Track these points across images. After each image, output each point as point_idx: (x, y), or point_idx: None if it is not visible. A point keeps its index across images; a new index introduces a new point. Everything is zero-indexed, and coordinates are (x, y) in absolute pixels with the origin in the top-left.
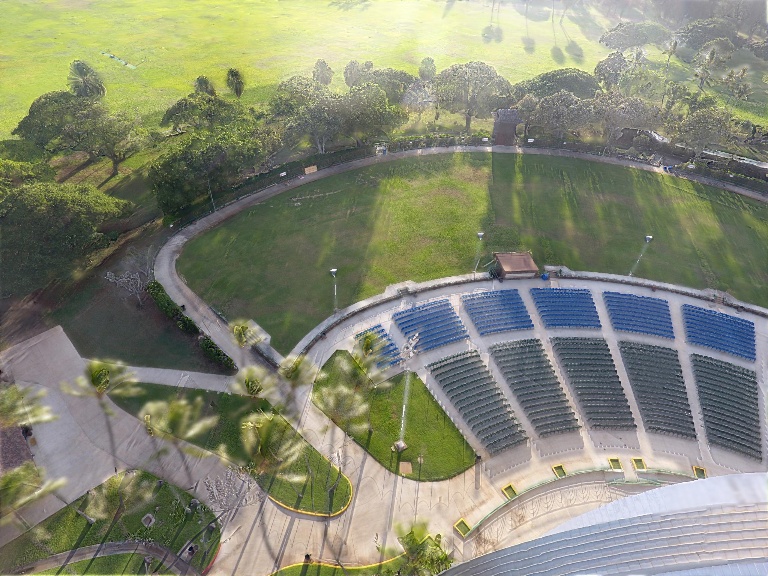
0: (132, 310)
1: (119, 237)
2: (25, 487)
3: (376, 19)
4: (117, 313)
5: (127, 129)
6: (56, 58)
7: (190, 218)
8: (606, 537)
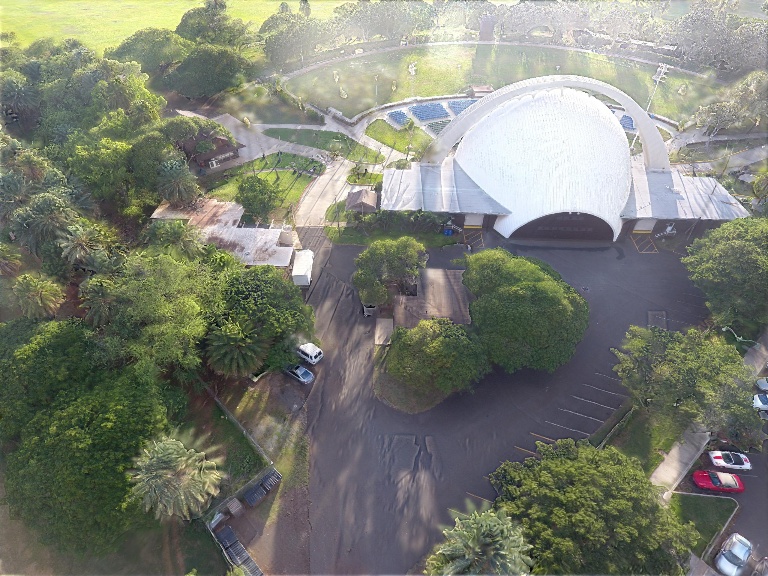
0: (266, 104)
1: (247, 84)
2: (240, 144)
3: None
4: (258, 106)
5: (244, 28)
6: (167, 6)
7: (290, 69)
8: None
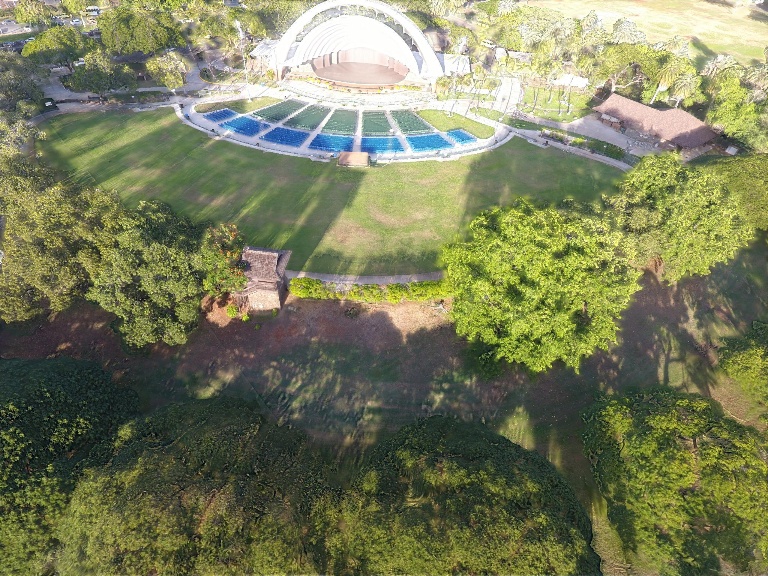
0: None
1: None
2: None
3: None
4: None
5: None
6: None
7: None
8: None
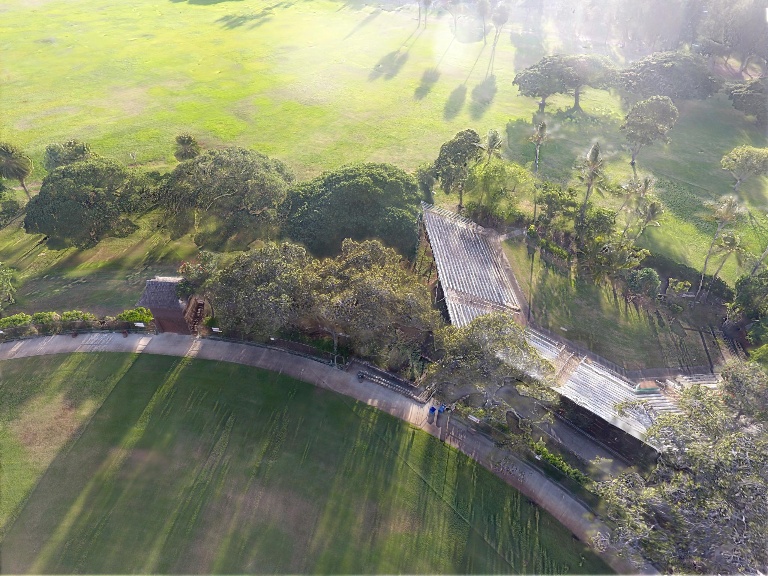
0: None
1: None
2: None
3: (255, 42)
4: None
5: None
6: None
7: None
8: None
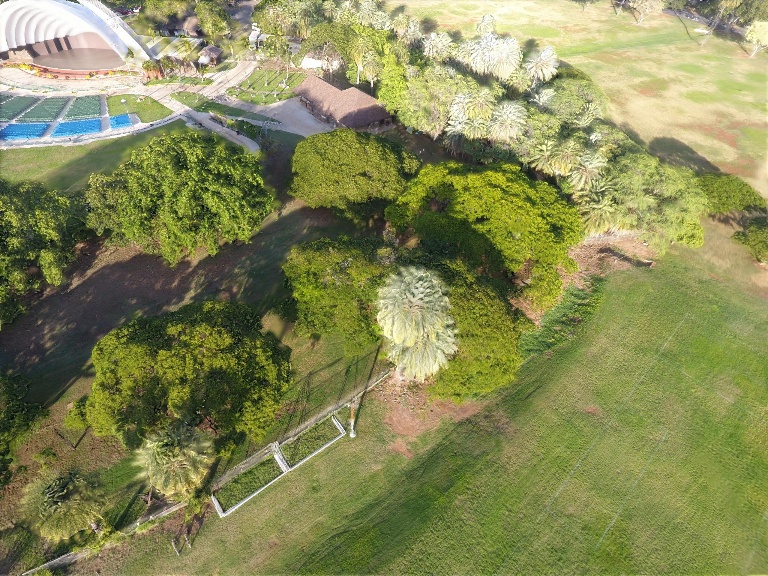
0: None
1: None
2: None
3: None
4: (285, 142)
5: None
6: None
7: None
8: (96, 4)
